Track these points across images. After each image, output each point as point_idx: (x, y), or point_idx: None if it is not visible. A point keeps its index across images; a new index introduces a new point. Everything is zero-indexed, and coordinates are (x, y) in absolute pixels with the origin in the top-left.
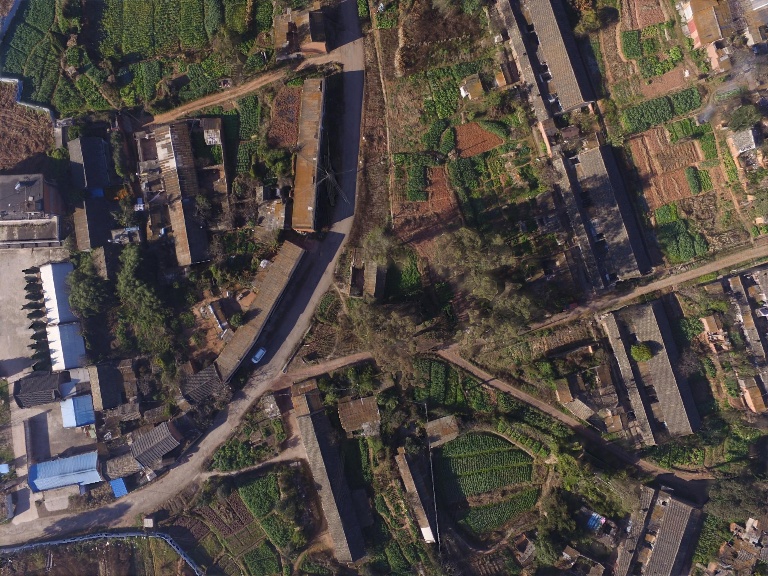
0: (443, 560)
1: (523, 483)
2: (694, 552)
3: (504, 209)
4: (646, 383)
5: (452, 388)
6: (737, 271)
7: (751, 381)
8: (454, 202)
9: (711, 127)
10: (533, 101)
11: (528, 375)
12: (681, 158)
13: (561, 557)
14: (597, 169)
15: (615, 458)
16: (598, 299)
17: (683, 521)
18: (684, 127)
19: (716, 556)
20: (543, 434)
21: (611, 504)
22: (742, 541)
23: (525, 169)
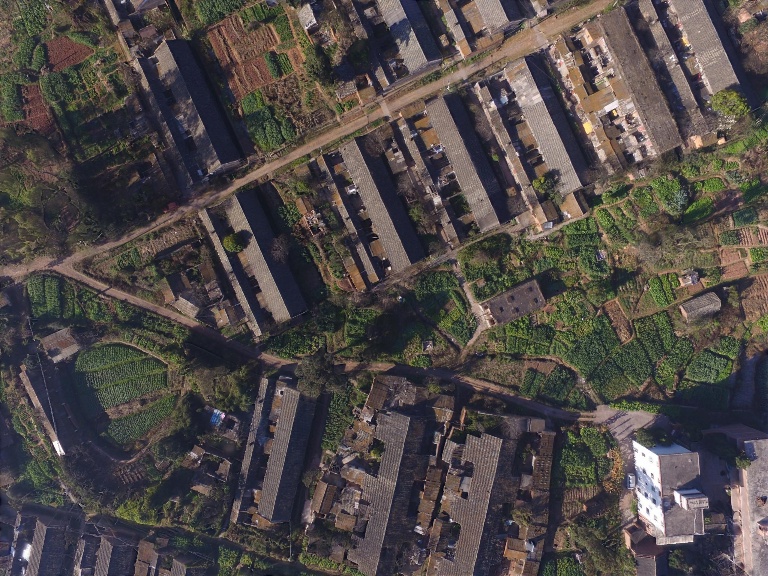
0: (71, 470)
1: (161, 390)
2: (322, 439)
3: (100, 118)
4: (249, 274)
5: (69, 302)
6: (328, 152)
7: (349, 260)
8: (50, 117)
9: (283, 9)
10: (106, 5)
11: (141, 281)
12: (258, 44)
13: (189, 457)
14: (169, 64)
15: (233, 353)
16: (199, 197)
17: (293, 407)
18: (256, 12)
19: (339, 440)
20: (169, 339)
21: (231, 399)
22: (360, 422)
23: (114, 75)
